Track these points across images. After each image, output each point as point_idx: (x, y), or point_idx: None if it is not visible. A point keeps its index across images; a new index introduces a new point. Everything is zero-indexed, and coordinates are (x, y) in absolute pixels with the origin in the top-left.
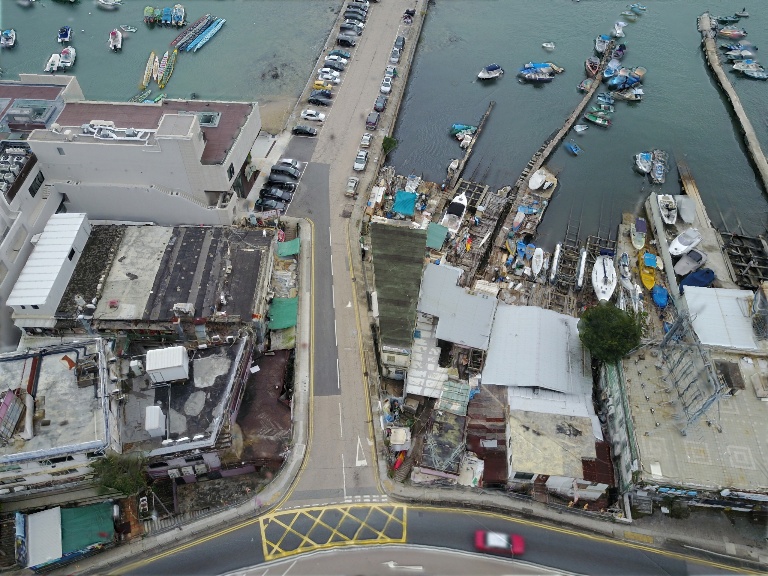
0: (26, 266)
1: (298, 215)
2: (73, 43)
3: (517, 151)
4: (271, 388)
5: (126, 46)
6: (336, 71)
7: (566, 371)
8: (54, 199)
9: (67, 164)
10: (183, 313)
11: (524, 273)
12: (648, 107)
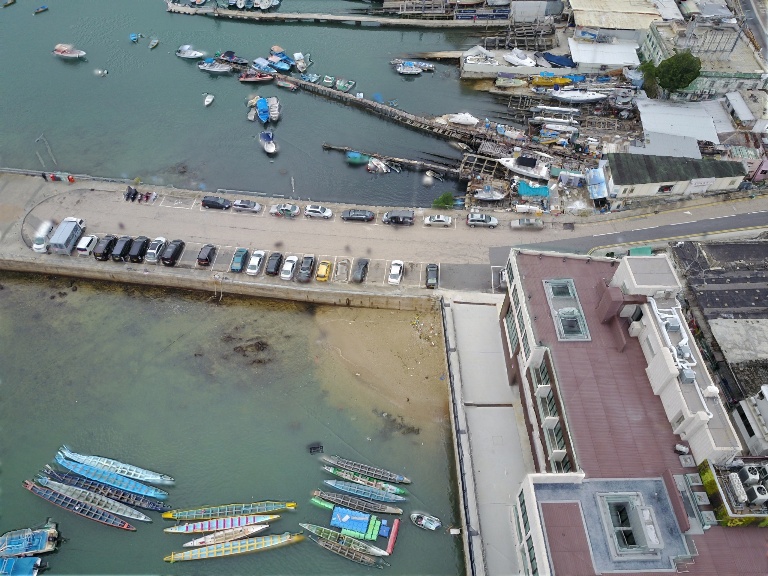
0: None
1: None
2: None
3: (397, 139)
4: None
5: None
6: None
7: (688, 108)
8: None
9: None
10: None
11: None
12: (319, 61)
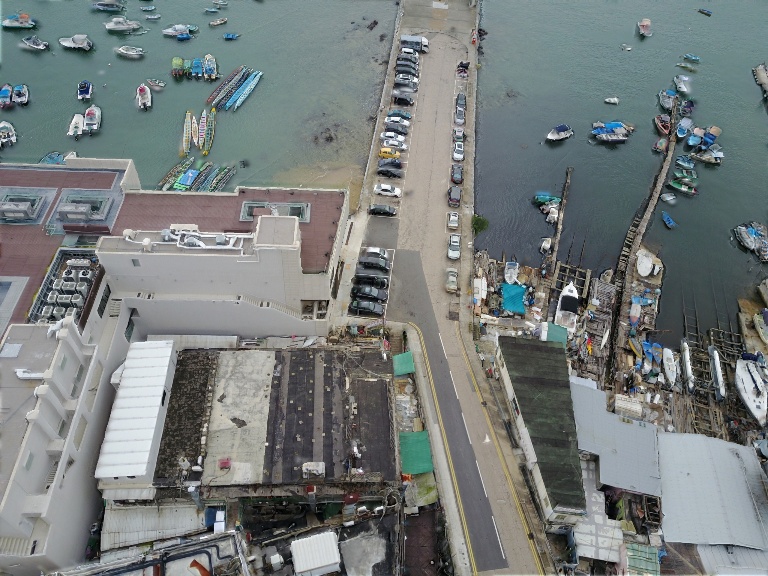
0: (111, 419)
1: (400, 319)
2: (95, 100)
3: (607, 225)
4: (425, 564)
5: (156, 104)
6: (400, 135)
7: (756, 520)
8: (124, 317)
9: (141, 276)
10: (314, 475)
11: (658, 380)
12: (729, 171)
